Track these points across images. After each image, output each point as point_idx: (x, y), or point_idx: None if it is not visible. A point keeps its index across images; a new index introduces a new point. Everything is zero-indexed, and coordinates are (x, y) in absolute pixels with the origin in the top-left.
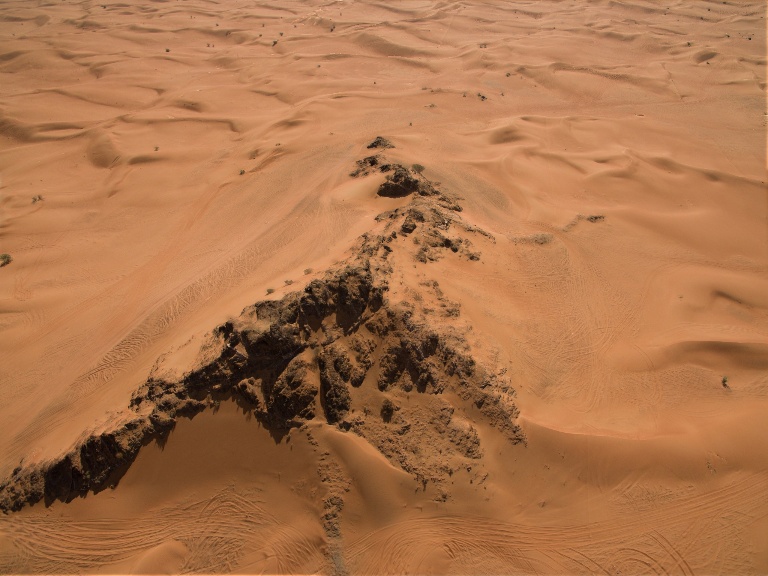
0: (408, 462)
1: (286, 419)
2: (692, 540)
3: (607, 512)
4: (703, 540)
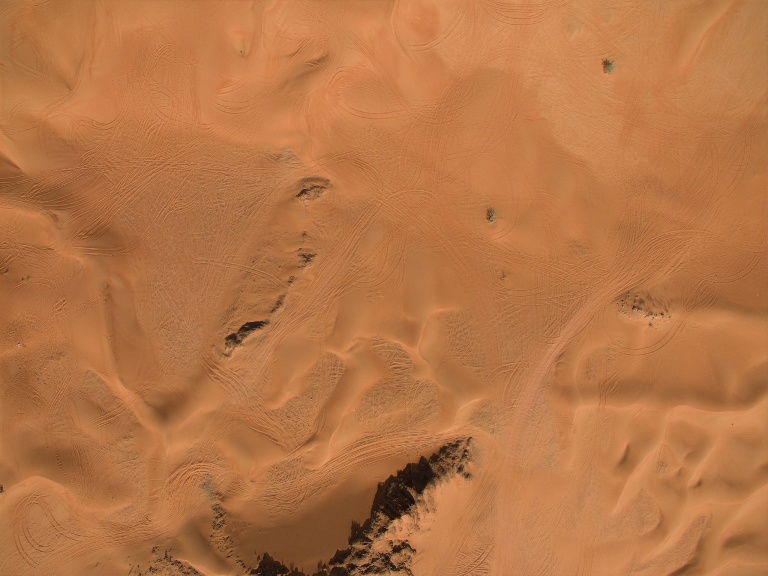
0: (178, 568)
1: (262, 574)
2: (16, 568)
3: (62, 571)
4: (10, 570)
